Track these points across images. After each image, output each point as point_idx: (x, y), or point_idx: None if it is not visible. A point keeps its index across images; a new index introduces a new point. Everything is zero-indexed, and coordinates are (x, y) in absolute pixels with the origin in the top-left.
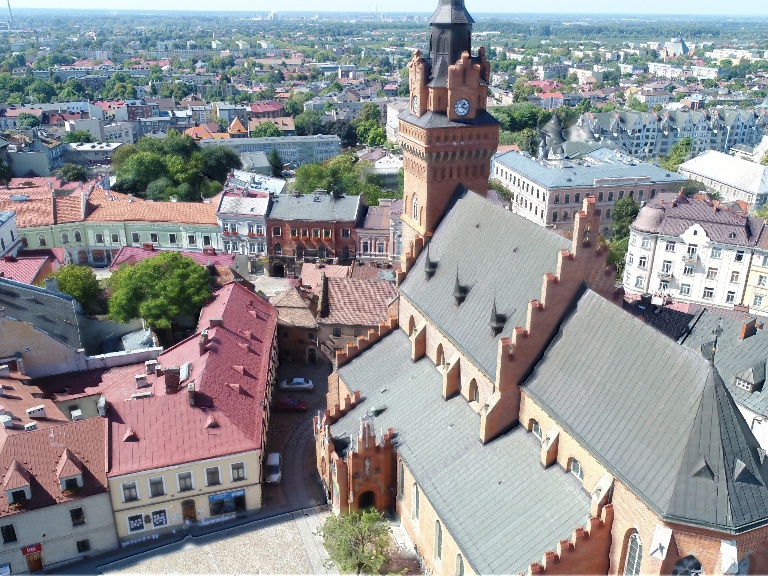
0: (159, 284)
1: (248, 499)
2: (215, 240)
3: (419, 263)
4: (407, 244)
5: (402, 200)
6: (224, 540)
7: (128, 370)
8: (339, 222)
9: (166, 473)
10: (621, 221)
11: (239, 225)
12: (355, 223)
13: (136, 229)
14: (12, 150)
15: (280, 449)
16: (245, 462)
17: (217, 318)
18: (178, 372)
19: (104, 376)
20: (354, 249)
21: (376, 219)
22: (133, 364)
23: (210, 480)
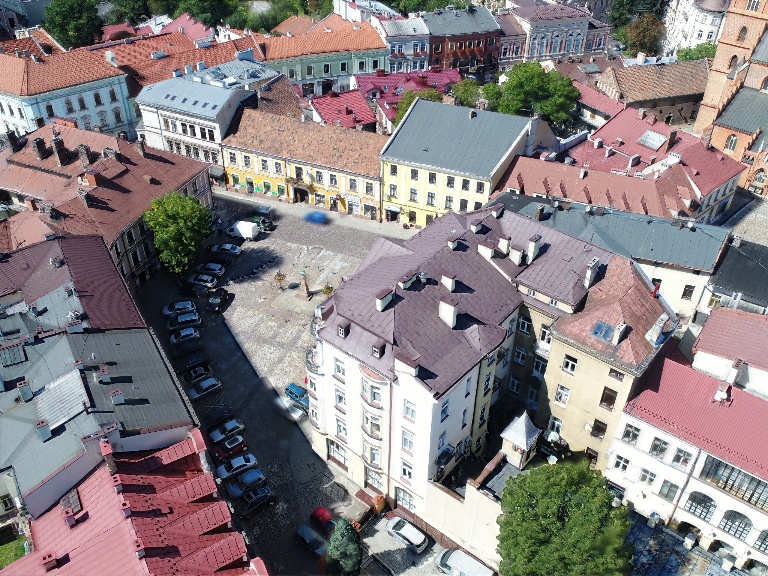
0: (550, 87)
1: (728, 203)
2: (383, 63)
3: (767, 40)
4: (735, 29)
5: (521, 8)
6: (734, 226)
7: (579, 149)
8: (488, 32)
9: None
10: (621, 10)
11: (406, 46)
12: None
13: (311, 62)
14: None
15: None
16: (737, 178)
17: (629, 101)
18: None
19: (572, 156)
20: (497, 55)
21: (509, 27)
22: (577, 145)
23: None
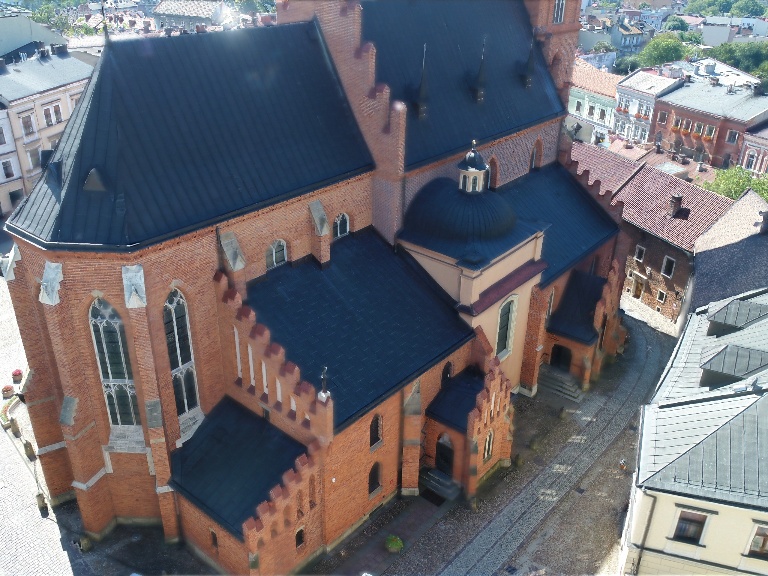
0: None
1: None
2: (609, 115)
3: None
4: None
5: None
6: None
7: None
8: (729, 120)
9: None
10: None
11: (632, 102)
12: (747, 126)
13: None
14: (585, 29)
15: None
16: None
17: None
18: None
19: None
20: (736, 160)
21: None
22: None
23: None
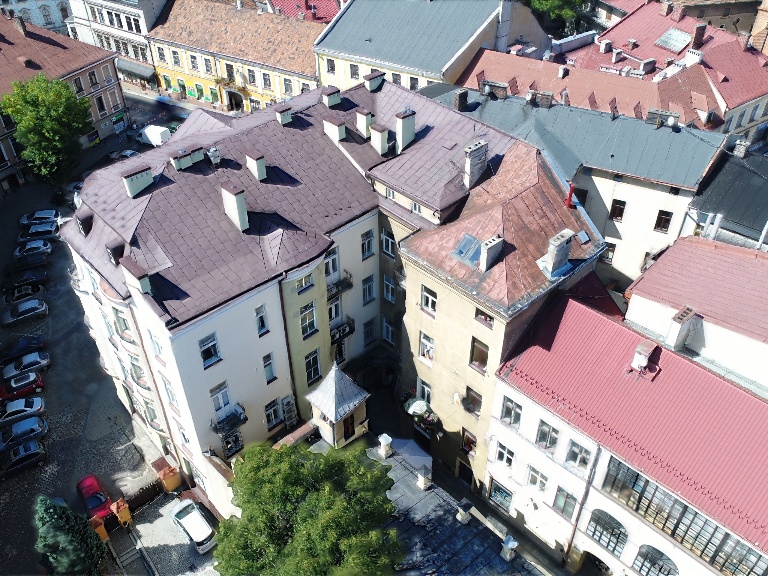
0: None
1: None
2: None
3: None
4: None
5: None
6: None
7: (580, 54)
8: None
9: (751, 105)
10: None
11: None
12: None
13: None
14: None
15: None
16: None
17: None
18: (705, 28)
19: None
20: None
21: None
22: (578, 49)
23: (763, 112)
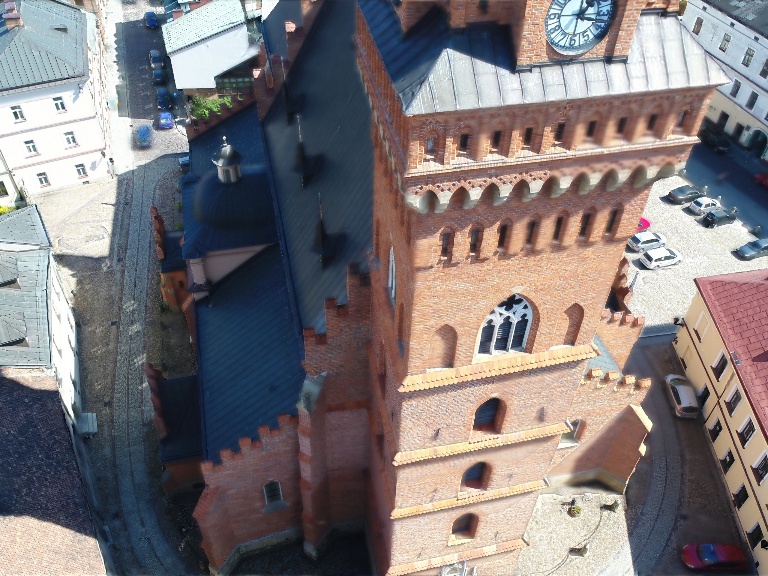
0: None
1: None
2: None
3: None
4: None
5: None
6: None
7: None
8: None
9: None
10: None
11: None
12: None
13: None
14: None
15: (690, 450)
16: None
17: None
18: None
19: None
20: None
21: None
22: None
23: None
